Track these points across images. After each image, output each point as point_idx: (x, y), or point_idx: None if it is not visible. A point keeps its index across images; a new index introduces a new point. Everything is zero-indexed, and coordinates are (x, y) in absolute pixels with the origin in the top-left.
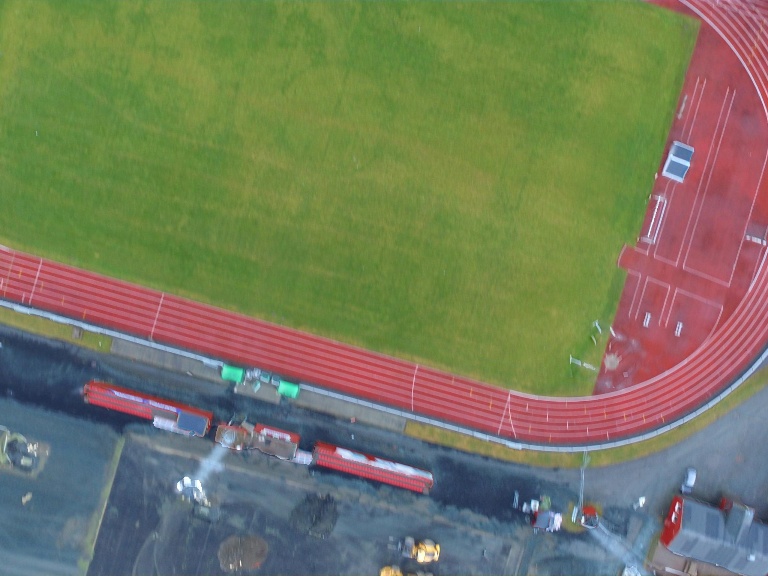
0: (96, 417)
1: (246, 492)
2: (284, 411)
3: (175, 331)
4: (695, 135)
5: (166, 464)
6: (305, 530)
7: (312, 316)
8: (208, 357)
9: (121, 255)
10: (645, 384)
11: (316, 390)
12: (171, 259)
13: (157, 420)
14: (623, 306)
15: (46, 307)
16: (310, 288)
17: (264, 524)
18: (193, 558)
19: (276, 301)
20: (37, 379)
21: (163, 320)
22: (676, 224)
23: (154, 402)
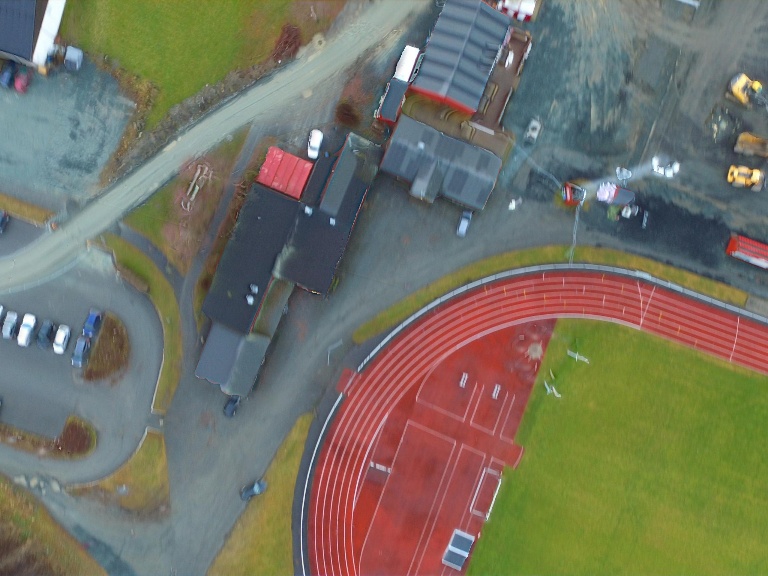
0: None
1: None
2: None
3: None
4: (438, 574)
5: None
6: None
7: None
8: None
9: None
10: (502, 326)
11: None
12: None
13: None
14: (521, 407)
15: None
16: None
17: None
18: None
19: None
20: None
21: None
22: (462, 487)
23: None
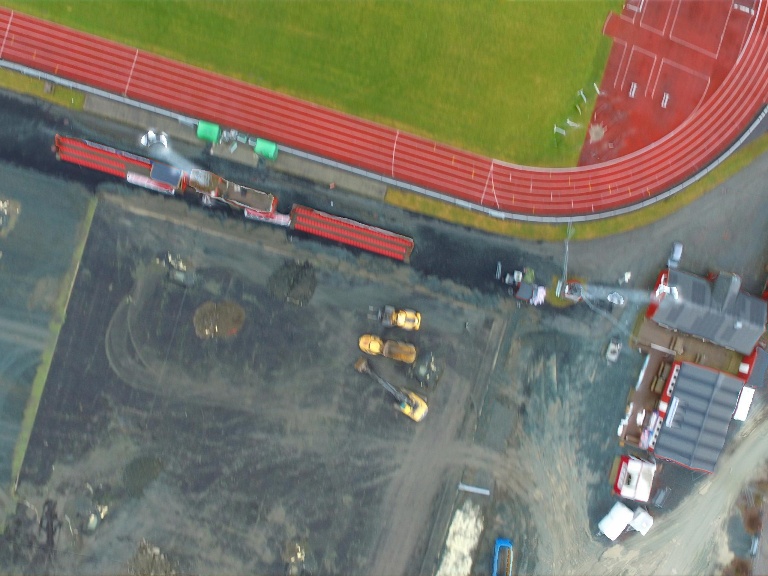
0: (68, 175)
1: (222, 257)
2: (262, 175)
3: (150, 89)
4: None
5: (140, 226)
6: (283, 296)
7: (290, 77)
8: (183, 115)
9: (94, 9)
10: (631, 156)
11: (294, 152)
12: (146, 14)
13: (131, 177)
14: (608, 75)
15: (17, 60)
16: (288, 48)
17: (241, 290)
18: (168, 324)
19: (253, 61)
20: (7, 134)
21: (137, 77)
22: None
23: (127, 153)
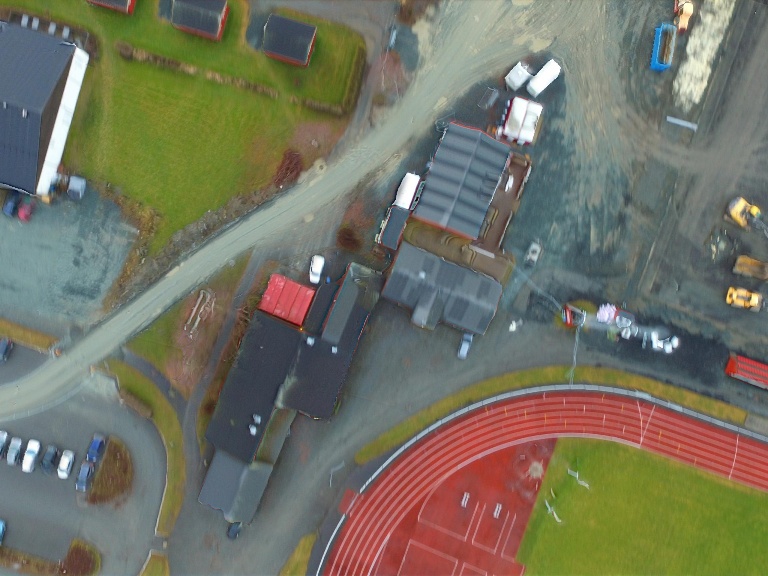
0: None
1: None
2: None
3: None
4: None
5: None
6: None
7: None
8: None
9: None
10: (503, 446)
11: None
12: None
13: None
14: (522, 526)
15: None
16: None
17: None
18: None
19: None
20: None
21: None
22: None
23: None
